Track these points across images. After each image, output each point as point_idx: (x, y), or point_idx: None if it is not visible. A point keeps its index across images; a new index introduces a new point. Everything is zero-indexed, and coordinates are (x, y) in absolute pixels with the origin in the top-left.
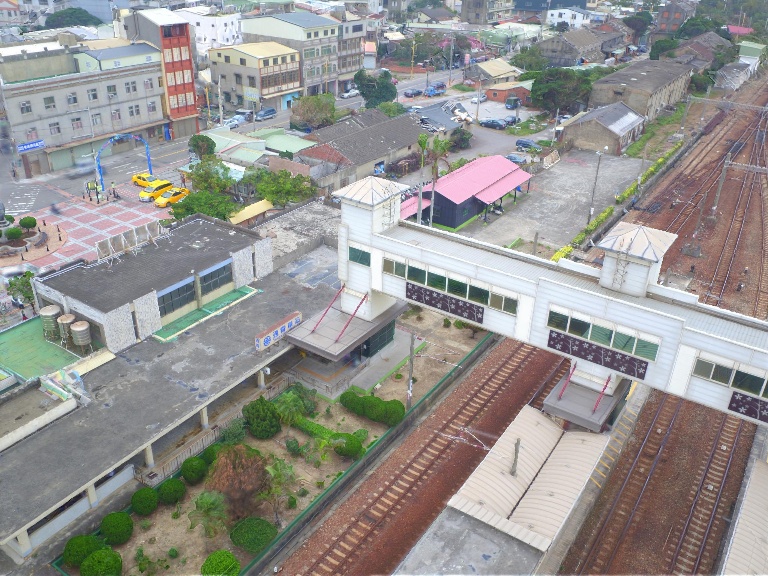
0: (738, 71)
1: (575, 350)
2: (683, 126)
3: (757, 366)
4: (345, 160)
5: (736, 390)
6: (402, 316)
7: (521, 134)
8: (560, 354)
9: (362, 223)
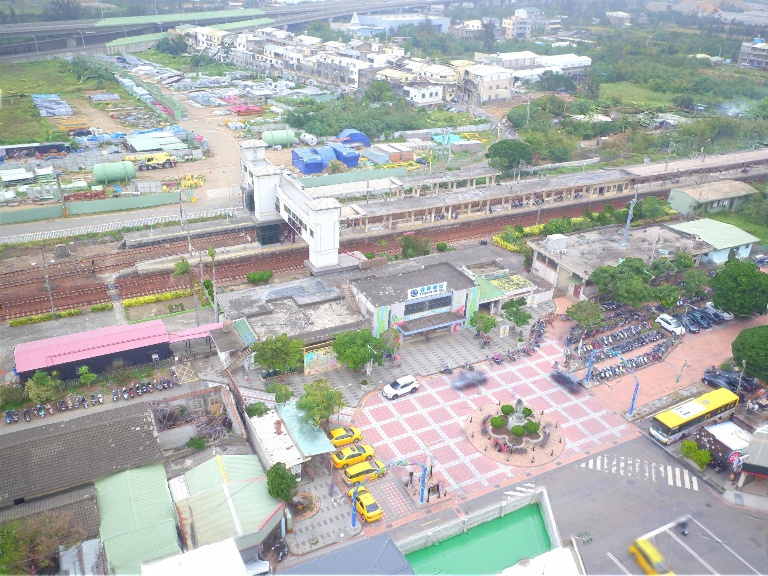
0: None
1: None
2: None
3: None
4: None
5: None
6: None
7: None
8: None
9: None
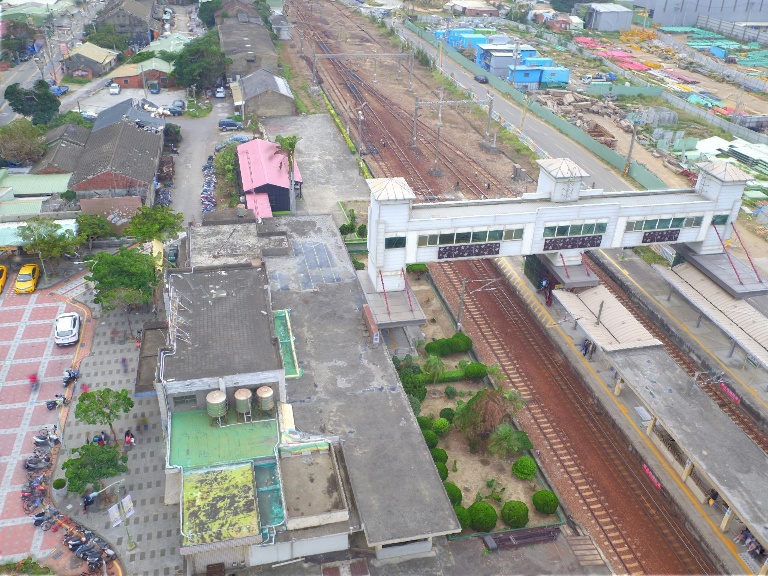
0: (287, 23)
1: (561, 246)
2: (314, 80)
3: (655, 214)
4: (136, 182)
5: (645, 231)
6: None
7: (203, 115)
8: (551, 252)
9: (399, 215)
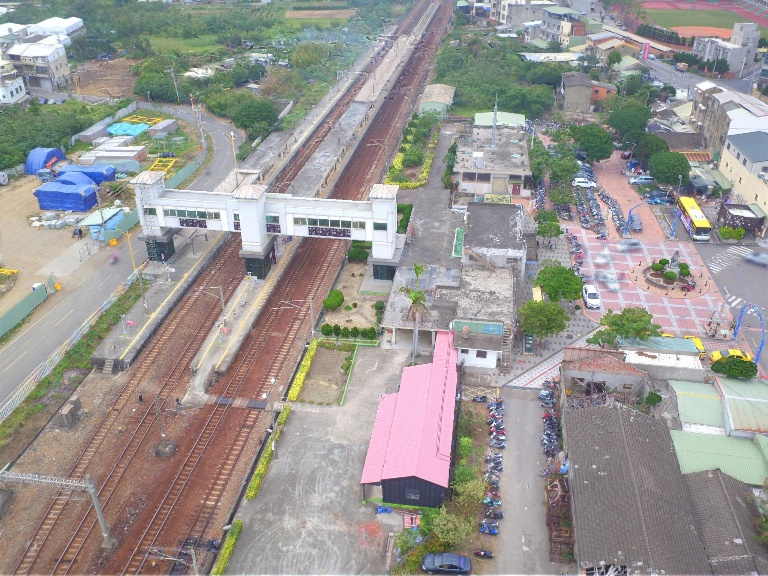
0: None
1: None
2: None
3: None
4: None
5: None
6: (385, 305)
7: None
8: None
9: None
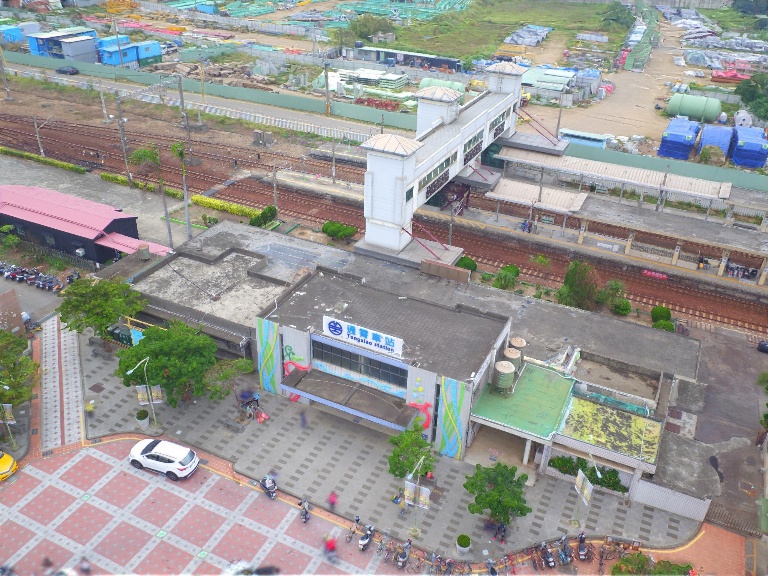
0: None
1: None
2: None
3: None
4: None
5: None
6: None
7: None
8: None
9: None
